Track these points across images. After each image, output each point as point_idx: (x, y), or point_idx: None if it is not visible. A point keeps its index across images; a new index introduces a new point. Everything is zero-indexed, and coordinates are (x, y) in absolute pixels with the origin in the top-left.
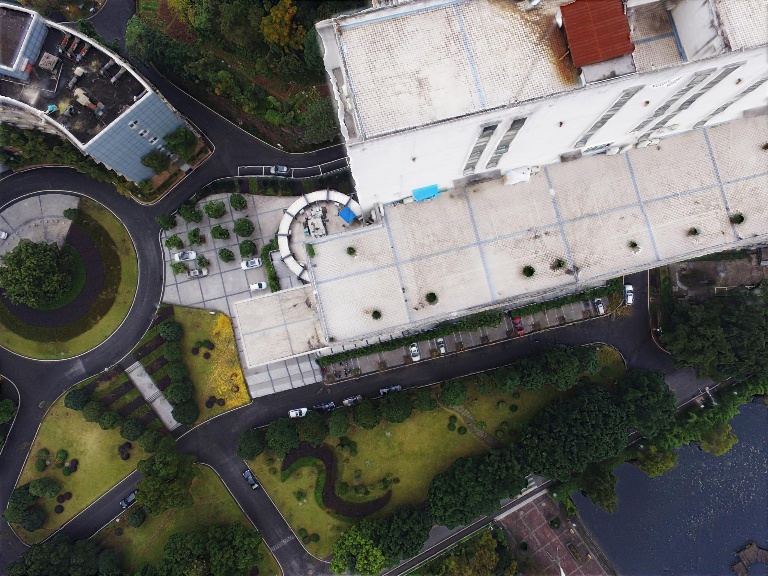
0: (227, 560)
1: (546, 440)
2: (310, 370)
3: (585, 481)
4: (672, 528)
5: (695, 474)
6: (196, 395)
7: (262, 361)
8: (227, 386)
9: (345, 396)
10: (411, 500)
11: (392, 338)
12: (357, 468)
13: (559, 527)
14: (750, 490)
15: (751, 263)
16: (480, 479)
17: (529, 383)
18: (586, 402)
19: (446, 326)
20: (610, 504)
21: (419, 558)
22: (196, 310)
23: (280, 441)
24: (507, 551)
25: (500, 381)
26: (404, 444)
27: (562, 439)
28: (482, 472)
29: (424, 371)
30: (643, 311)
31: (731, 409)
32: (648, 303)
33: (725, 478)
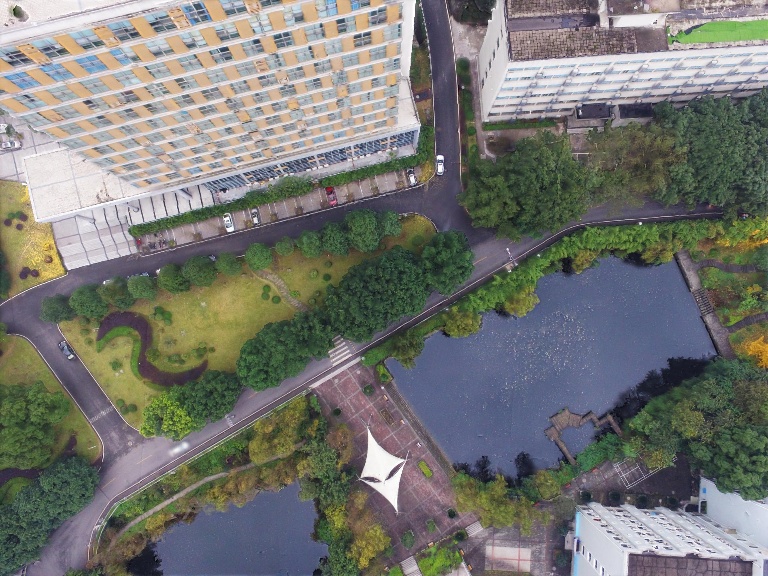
0: (18, 411)
1: (343, 297)
2: (124, 241)
3: (393, 344)
4: (487, 395)
5: (510, 342)
6: (10, 267)
7: (50, 214)
8: (41, 257)
9: (159, 266)
10: (228, 370)
11: (203, 207)
12: (173, 338)
13: (373, 394)
14: (563, 357)
15: (558, 131)
16: (282, 338)
17: (328, 243)
18: (383, 260)
19: (254, 193)
20: (407, 359)
21: (236, 427)
22: (9, 182)
23: (79, 300)
24: (320, 417)
25: (300, 241)
26: (219, 314)
27: (357, 295)
28: (286, 333)
29: (239, 242)
30: (455, 181)
31: (533, 270)
32: (460, 173)
33: (539, 346)
